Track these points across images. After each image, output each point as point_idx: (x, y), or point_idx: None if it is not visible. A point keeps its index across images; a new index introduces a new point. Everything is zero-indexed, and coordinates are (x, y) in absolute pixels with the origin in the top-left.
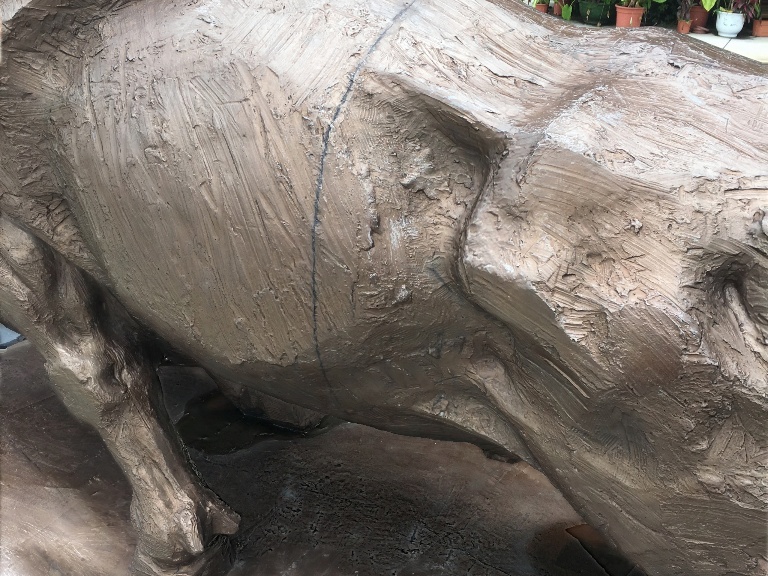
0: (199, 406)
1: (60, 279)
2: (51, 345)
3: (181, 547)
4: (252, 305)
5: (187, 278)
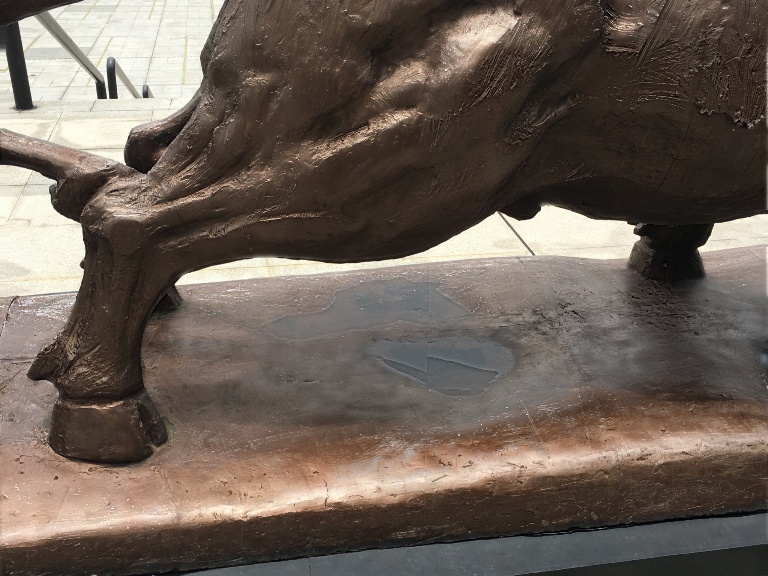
0: None
1: None
2: None
3: None
4: None
5: None
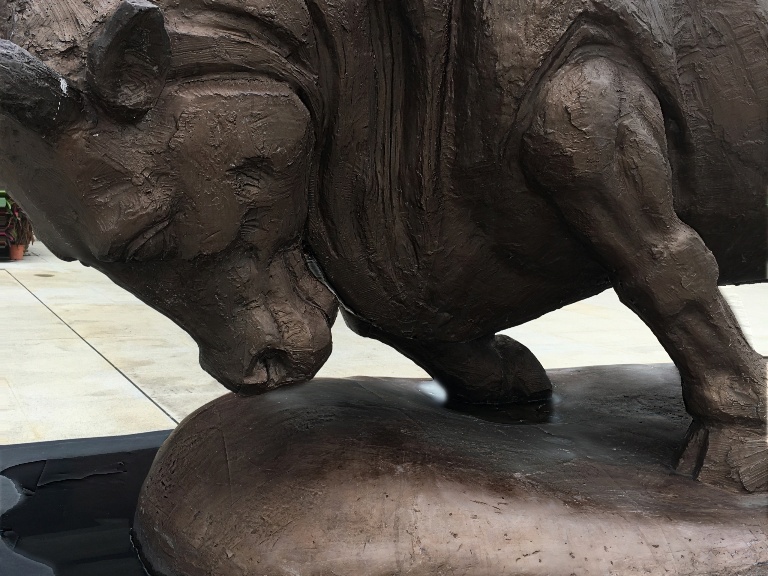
0: (459, 411)
1: None
2: None
3: None
4: None
5: None
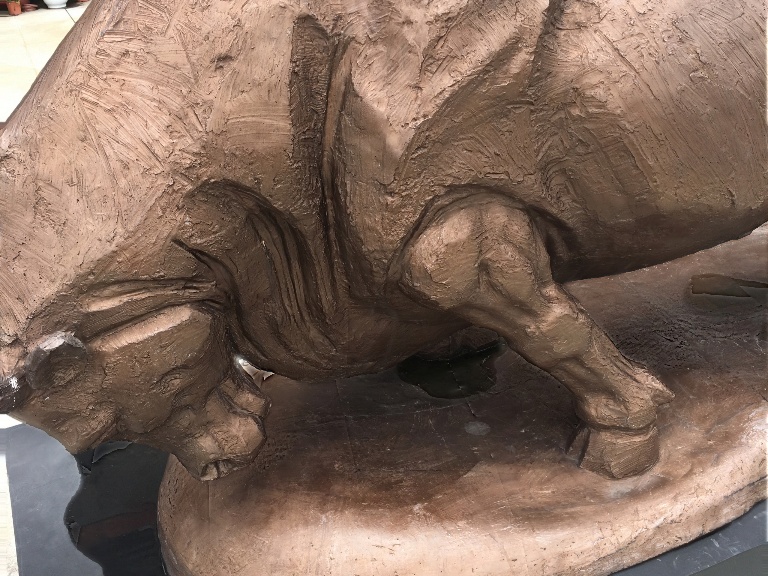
0: (412, 377)
1: None
2: (544, 304)
3: (657, 405)
4: None
5: (733, 158)
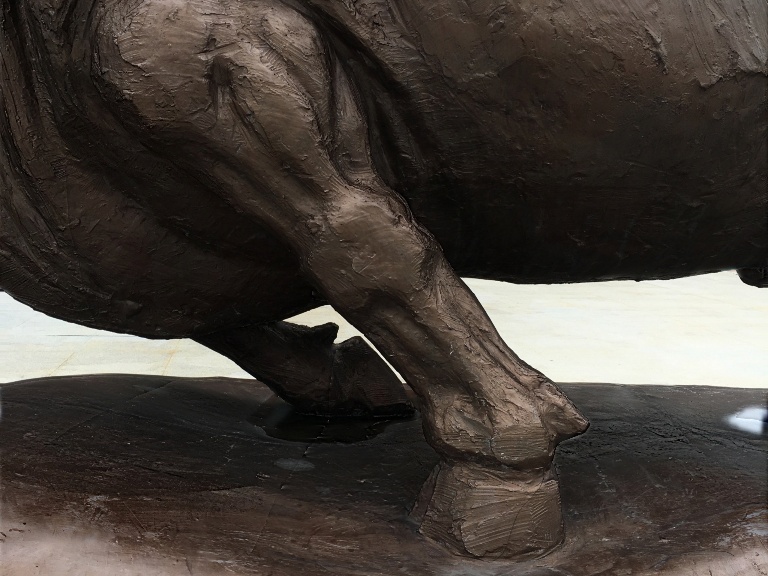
0: (265, 421)
1: (336, 90)
2: (337, 179)
3: (554, 433)
4: (737, 1)
5: None
